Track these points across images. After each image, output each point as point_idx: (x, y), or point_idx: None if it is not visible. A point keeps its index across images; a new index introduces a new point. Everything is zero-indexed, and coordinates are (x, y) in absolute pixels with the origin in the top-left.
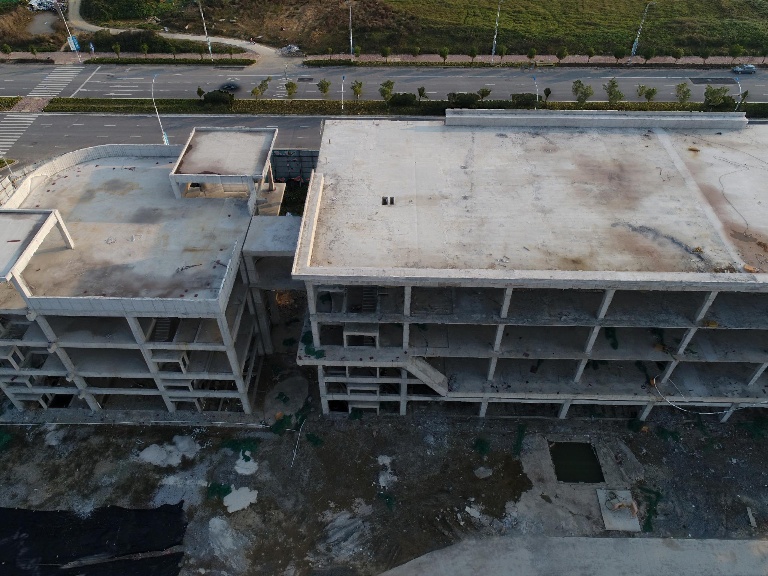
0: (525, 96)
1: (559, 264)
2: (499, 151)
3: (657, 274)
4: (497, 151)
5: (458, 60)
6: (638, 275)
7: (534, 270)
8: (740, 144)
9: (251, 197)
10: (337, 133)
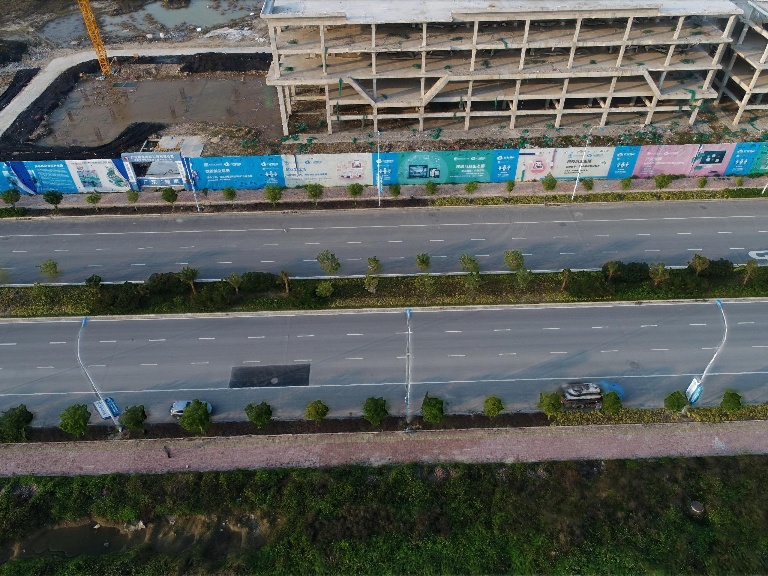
0: (597, 282)
1: None
2: (614, 1)
3: None
4: (615, 1)
5: (757, 430)
6: None
7: None
8: None
9: (747, 8)
10: (726, 5)
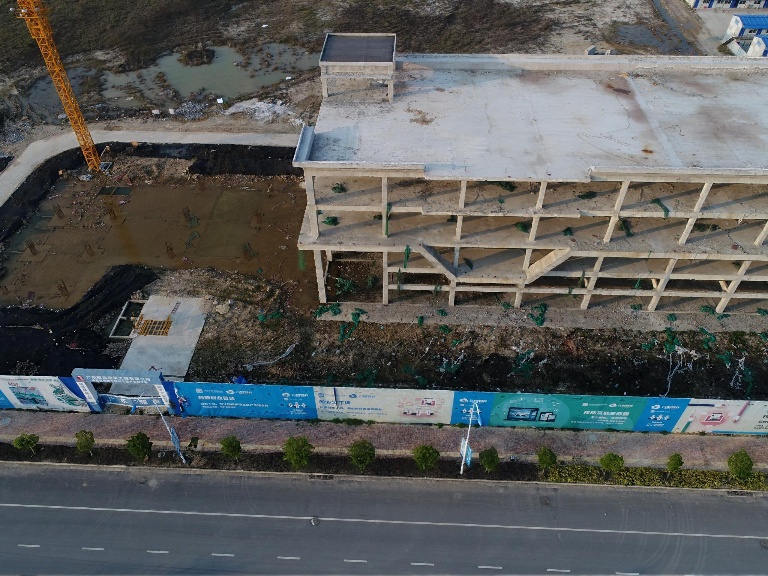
0: None
1: (747, 78)
2: None
3: (688, 63)
4: None
5: None
6: (700, 62)
7: (764, 66)
8: (600, 157)
9: None
10: None
